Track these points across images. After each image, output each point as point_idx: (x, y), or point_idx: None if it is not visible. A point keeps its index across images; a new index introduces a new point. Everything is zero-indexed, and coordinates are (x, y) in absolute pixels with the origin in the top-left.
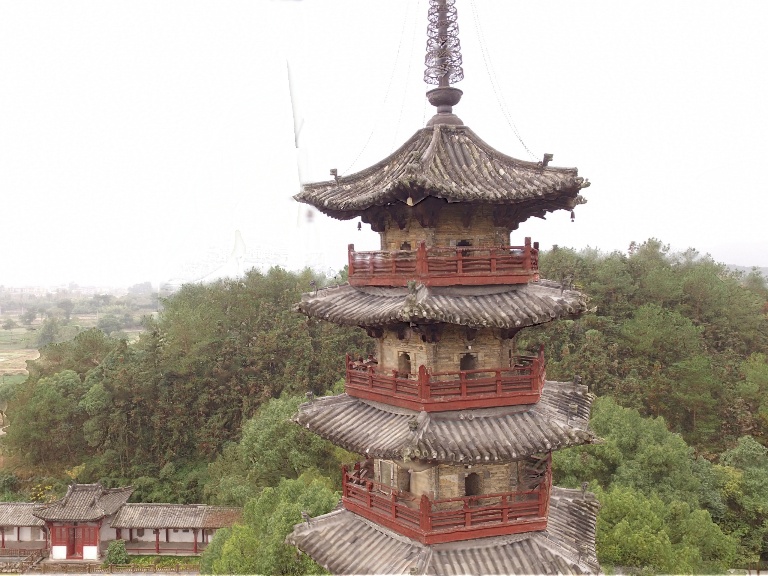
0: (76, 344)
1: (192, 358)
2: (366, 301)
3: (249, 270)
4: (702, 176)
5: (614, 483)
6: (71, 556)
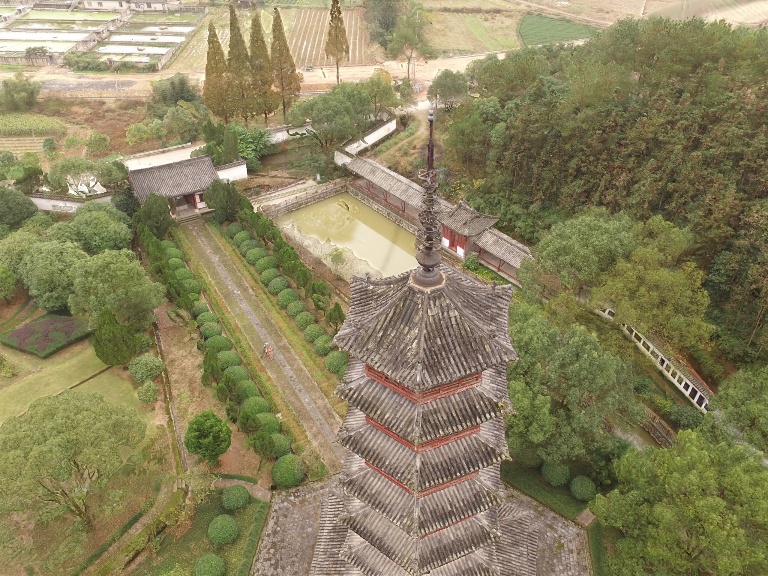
0: (512, 68)
1: (576, 123)
2: None
3: (688, 19)
4: None
5: None
6: (451, 247)
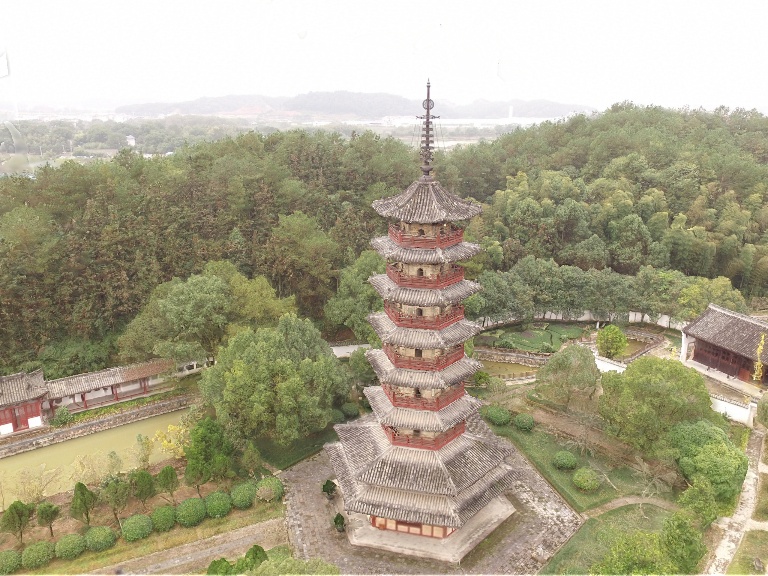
0: None
1: (45, 258)
2: (412, 253)
3: (43, 165)
4: (355, 40)
5: None
6: (17, 429)
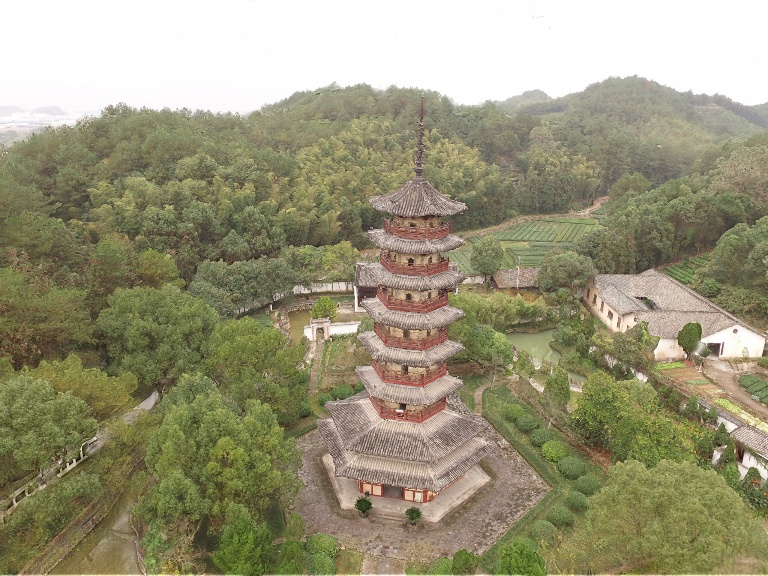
0: None
1: None
2: None
3: None
4: None
5: (218, 324)
6: None
